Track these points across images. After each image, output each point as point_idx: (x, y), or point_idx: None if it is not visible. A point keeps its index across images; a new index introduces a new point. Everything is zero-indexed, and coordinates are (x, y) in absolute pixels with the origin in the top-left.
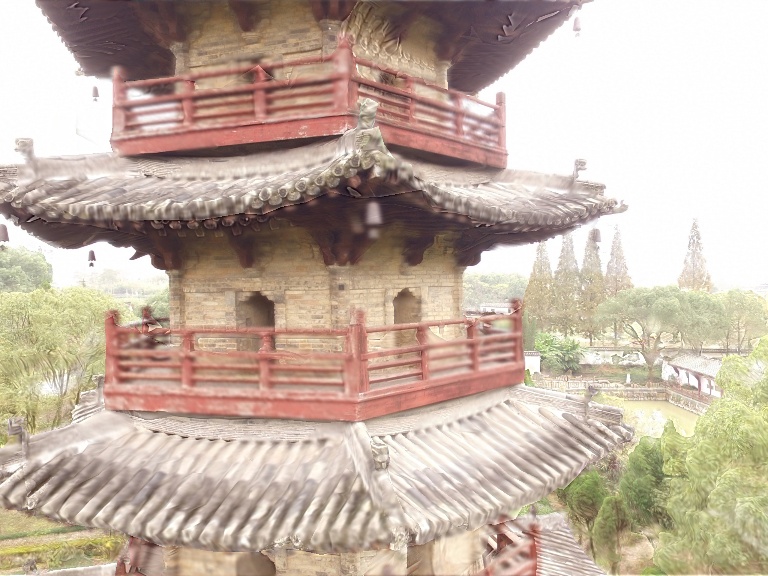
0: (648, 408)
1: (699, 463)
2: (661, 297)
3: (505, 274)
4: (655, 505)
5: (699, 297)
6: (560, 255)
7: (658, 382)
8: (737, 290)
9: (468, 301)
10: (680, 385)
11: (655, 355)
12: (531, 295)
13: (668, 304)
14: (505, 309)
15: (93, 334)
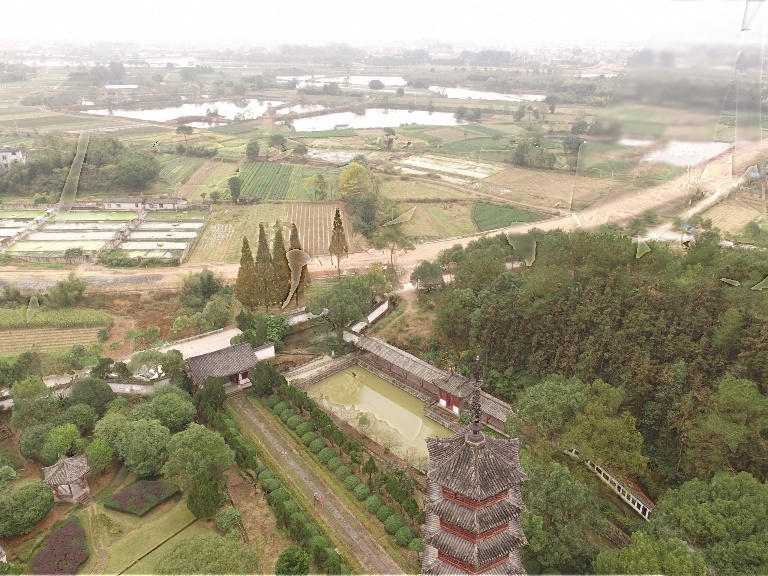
0: (348, 371)
1: None
2: (349, 306)
3: (101, 144)
4: None
5: (358, 286)
6: (259, 252)
7: (347, 349)
8: (320, 176)
9: None
10: (358, 347)
11: (342, 330)
12: (244, 286)
13: (354, 311)
14: (132, 204)
15: None
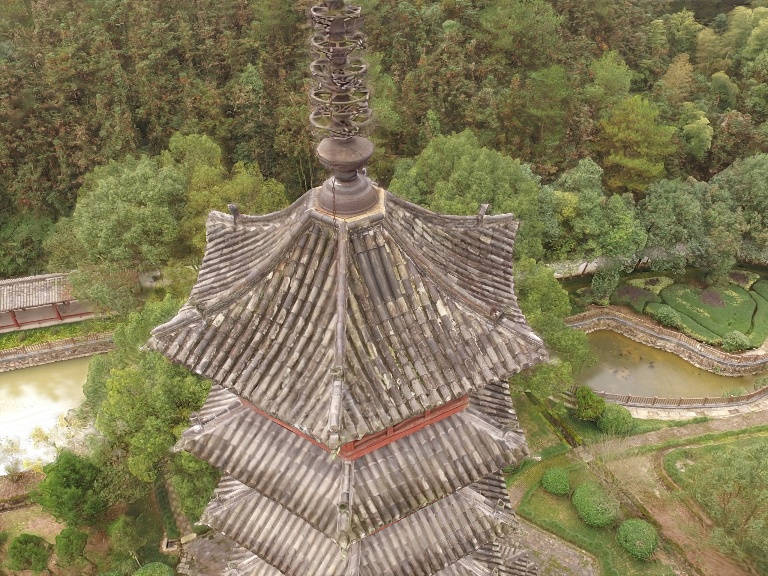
0: None
1: (195, 462)
2: None
3: None
4: (112, 500)
5: None
6: None
7: None
8: None
9: None
10: None
11: None
12: None
13: None
14: None
15: None
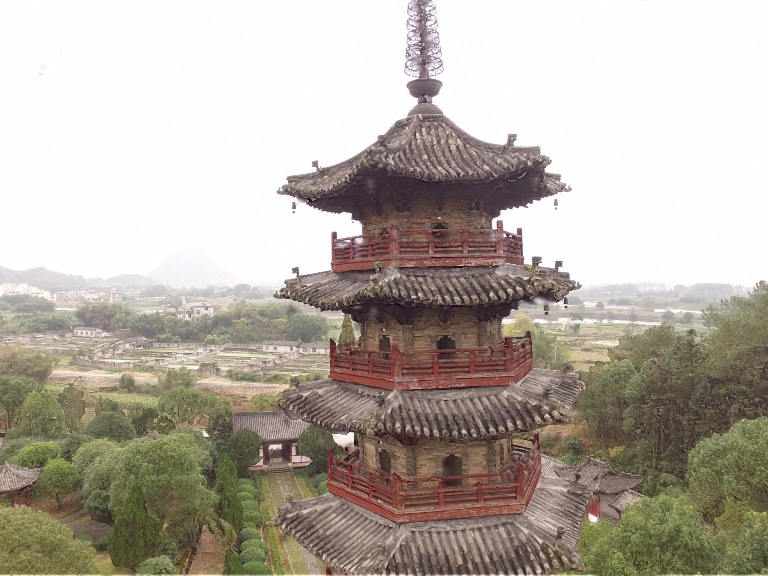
0: None
1: None
2: None
3: (281, 306)
4: None
5: None
6: None
7: None
8: None
9: (247, 336)
10: None
11: None
12: None
13: None
14: (287, 347)
15: (44, 568)
